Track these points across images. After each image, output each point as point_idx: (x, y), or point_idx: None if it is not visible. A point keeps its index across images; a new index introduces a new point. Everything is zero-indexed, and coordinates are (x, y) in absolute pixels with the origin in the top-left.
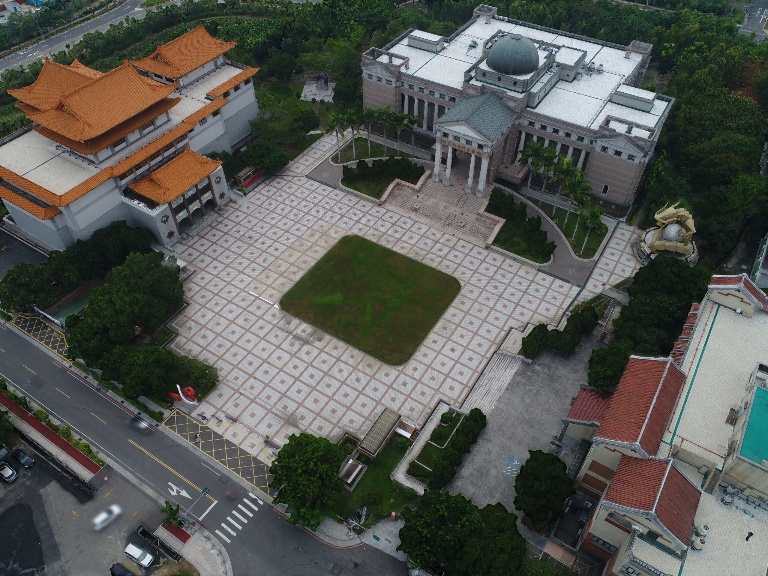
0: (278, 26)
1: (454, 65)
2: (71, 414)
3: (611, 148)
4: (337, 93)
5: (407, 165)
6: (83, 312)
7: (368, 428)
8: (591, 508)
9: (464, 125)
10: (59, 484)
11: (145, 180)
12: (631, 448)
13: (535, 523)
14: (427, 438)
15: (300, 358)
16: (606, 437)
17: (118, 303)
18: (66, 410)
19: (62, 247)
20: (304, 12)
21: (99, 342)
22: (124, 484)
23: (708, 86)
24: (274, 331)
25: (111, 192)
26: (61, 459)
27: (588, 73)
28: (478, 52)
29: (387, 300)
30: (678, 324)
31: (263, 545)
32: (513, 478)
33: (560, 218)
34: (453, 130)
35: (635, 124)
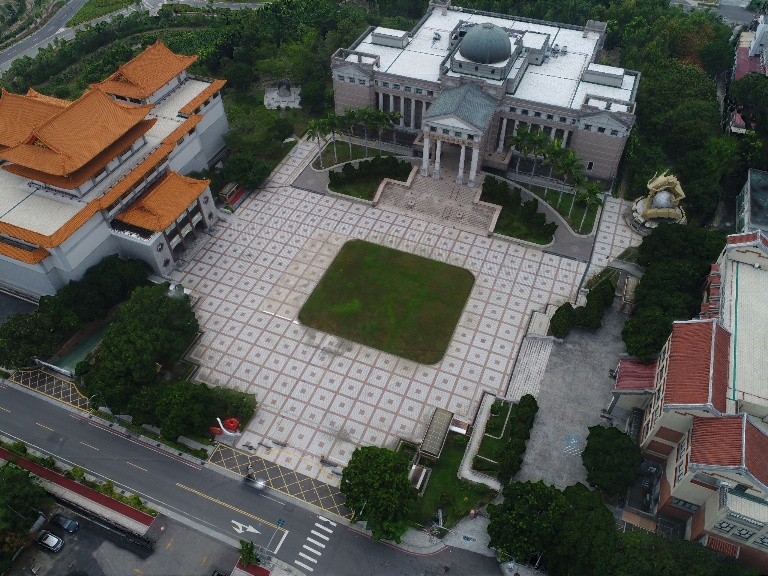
0: (226, 35)
1: (424, 59)
2: (105, 467)
3: (594, 125)
4: (304, 98)
5: (394, 163)
6: (90, 357)
7: (421, 431)
8: (655, 473)
9: (453, 117)
10: (112, 543)
11: (134, 209)
12: (704, 409)
13: (609, 496)
14: (482, 431)
15: (334, 371)
16: (676, 402)
17: (138, 342)
18: (98, 464)
19: (51, 291)
20: (251, 18)
21: (124, 386)
22: (184, 531)
23: (659, 58)
24: (300, 348)
25: (99, 226)
26: (107, 516)
27: (554, 55)
28: (443, 44)
29: (406, 300)
30: (697, 286)
31: (348, 567)
32: (575, 456)
33: (551, 198)
34: (441, 123)
35: (614, 100)
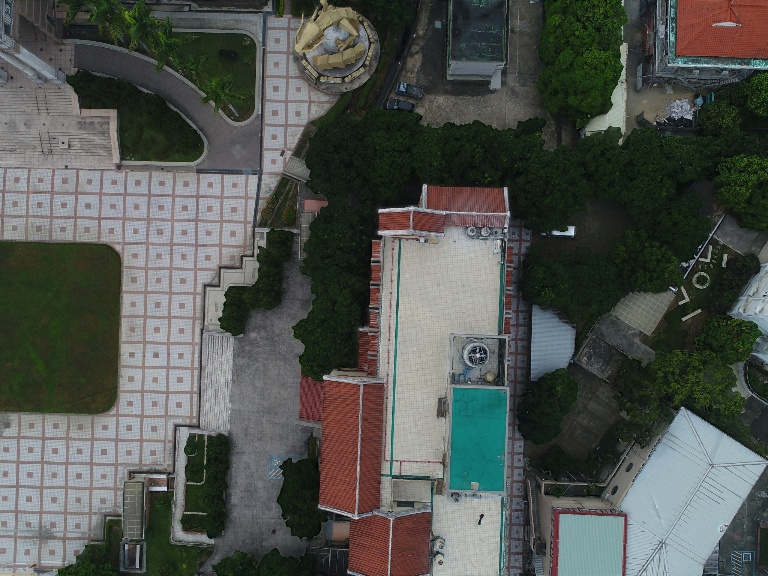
0: None
1: None
2: None
3: None
4: None
5: None
6: None
7: None
8: None
9: None
10: None
11: None
12: None
13: None
14: (184, 479)
15: (2, 461)
16: (329, 505)
17: None
18: None
19: None
20: None
21: None
22: None
23: None
24: None
25: None
26: None
27: None
28: None
29: (46, 327)
30: (371, 242)
31: None
32: (280, 480)
33: None
34: None
35: None
